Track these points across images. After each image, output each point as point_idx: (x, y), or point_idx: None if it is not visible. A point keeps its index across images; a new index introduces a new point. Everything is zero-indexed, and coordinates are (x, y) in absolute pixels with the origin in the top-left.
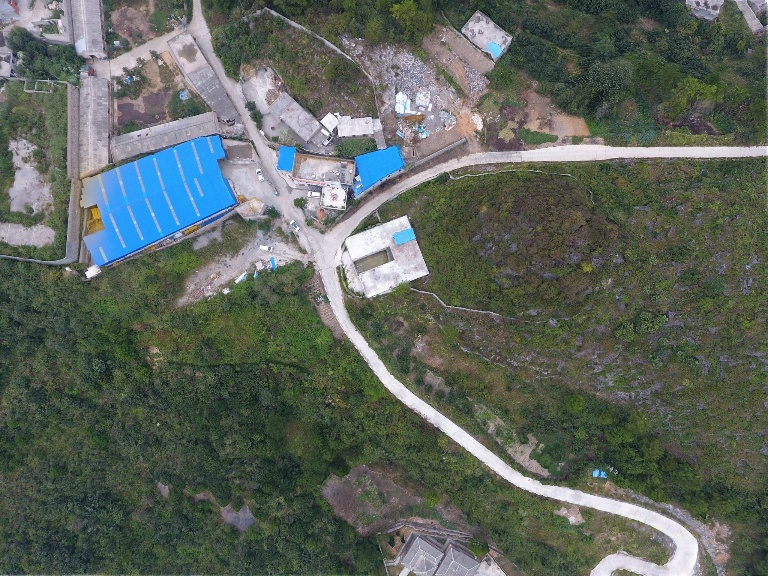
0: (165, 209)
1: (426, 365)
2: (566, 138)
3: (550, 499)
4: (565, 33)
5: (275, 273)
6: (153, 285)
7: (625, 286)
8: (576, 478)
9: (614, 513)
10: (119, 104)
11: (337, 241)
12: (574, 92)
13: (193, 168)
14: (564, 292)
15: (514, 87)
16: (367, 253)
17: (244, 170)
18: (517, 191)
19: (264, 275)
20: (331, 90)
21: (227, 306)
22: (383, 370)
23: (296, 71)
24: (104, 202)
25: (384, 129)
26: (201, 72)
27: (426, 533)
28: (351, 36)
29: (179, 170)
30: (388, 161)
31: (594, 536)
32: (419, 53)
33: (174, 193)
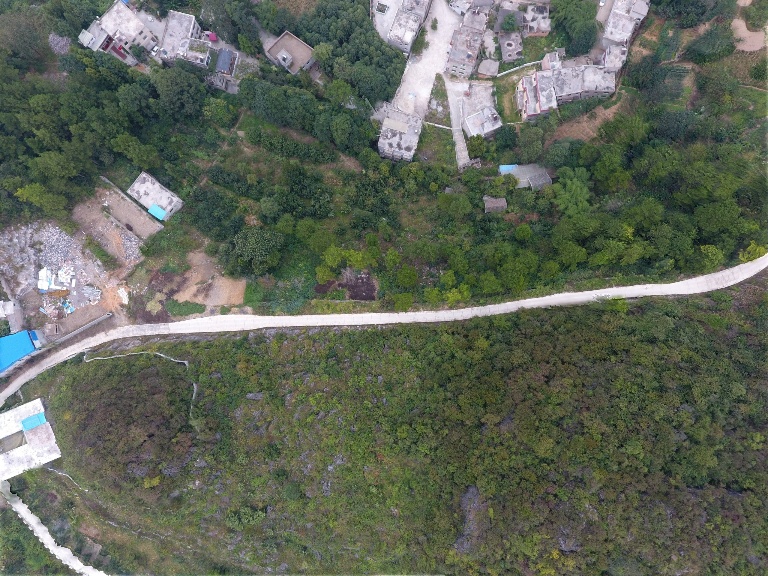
0: None
1: (84, 534)
2: (214, 308)
3: None
4: (249, 182)
5: None
6: None
7: (223, 482)
8: None
9: None
10: None
11: None
12: (226, 260)
13: None
14: None
15: (177, 250)
16: (1, 437)
17: None
18: (102, 396)
19: None
20: None
21: None
22: (49, 536)
23: None
24: None
25: (25, 308)
26: None
27: None
28: None
29: None
30: (17, 346)
31: None
32: (63, 228)
33: None
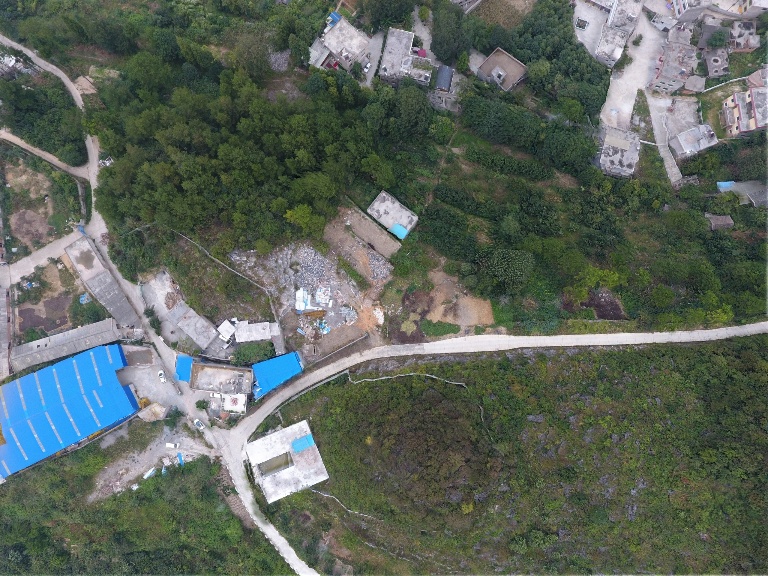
0: (65, 421)
1: (334, 555)
2: (468, 329)
3: None
4: (476, 200)
5: (182, 470)
6: (59, 489)
7: (515, 505)
8: None
9: None
10: (20, 310)
11: (243, 436)
12: (477, 279)
13: (92, 380)
14: (449, 523)
15: (420, 269)
16: (267, 459)
17: (147, 371)
18: (402, 420)
19: (172, 470)
20: (227, 298)
21: (135, 503)
22: (294, 557)
23: (190, 283)
24: (5, 416)
25: (284, 328)
26: (99, 278)
27: None
28: (242, 250)
29: (78, 382)
30: (285, 368)
31: None
32: (319, 248)
33: (73, 406)
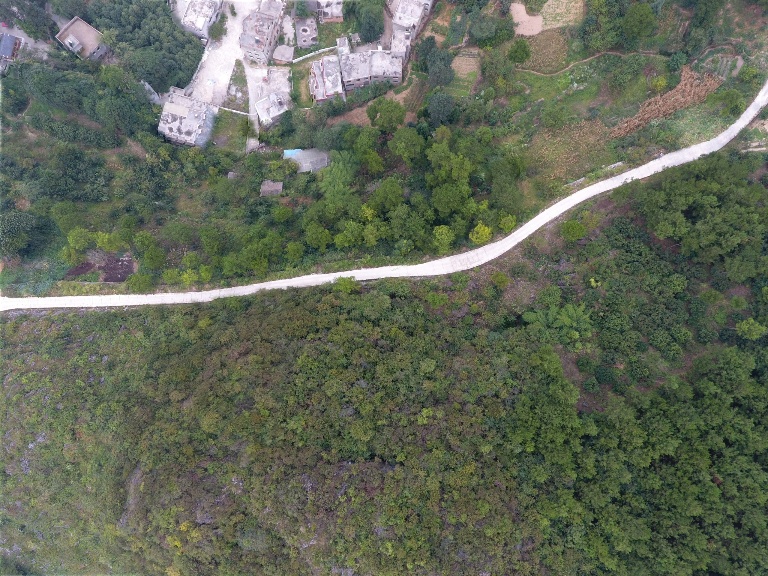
0: None
1: None
2: None
3: None
4: (25, 166)
5: None
6: None
7: None
8: None
9: None
10: None
11: None
12: None
13: None
14: None
15: None
16: None
17: None
18: None
19: None
20: None
21: None
22: None
23: None
24: None
25: None
26: None
27: None
28: None
29: None
30: None
31: None
32: None
33: None
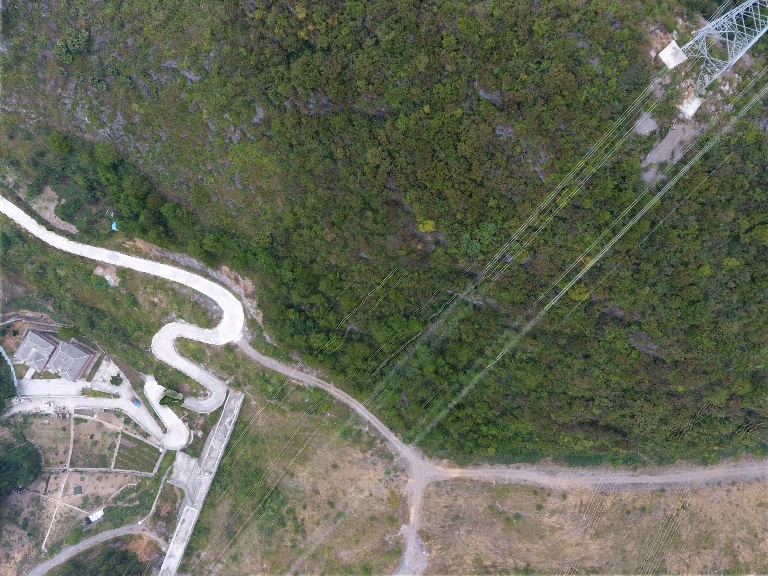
0: None
1: None
2: None
3: (86, 259)
4: None
5: None
6: None
7: (48, 3)
8: (90, 228)
9: (153, 274)
10: None
11: None
12: None
13: None
14: None
15: None
16: None
17: None
18: None
19: None
20: None
21: None
22: None
23: None
24: None
25: None
26: None
27: (40, 328)
28: None
29: None
30: None
31: (134, 296)
32: None
33: None
